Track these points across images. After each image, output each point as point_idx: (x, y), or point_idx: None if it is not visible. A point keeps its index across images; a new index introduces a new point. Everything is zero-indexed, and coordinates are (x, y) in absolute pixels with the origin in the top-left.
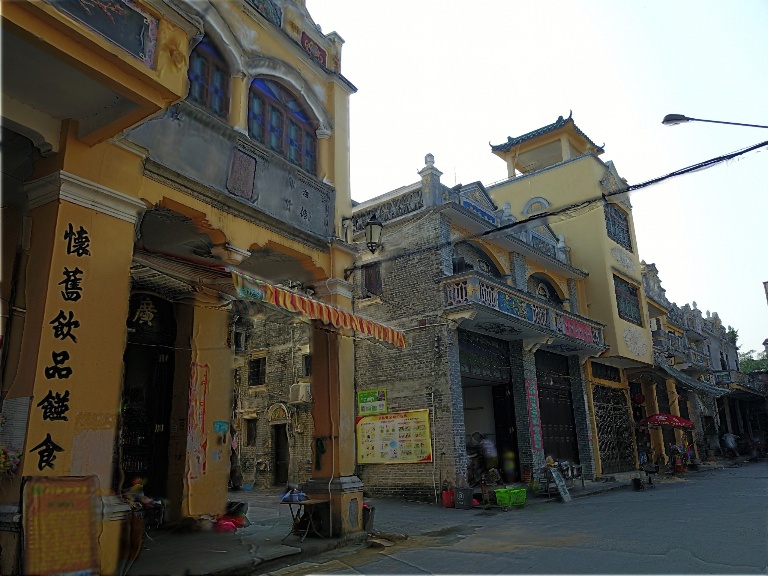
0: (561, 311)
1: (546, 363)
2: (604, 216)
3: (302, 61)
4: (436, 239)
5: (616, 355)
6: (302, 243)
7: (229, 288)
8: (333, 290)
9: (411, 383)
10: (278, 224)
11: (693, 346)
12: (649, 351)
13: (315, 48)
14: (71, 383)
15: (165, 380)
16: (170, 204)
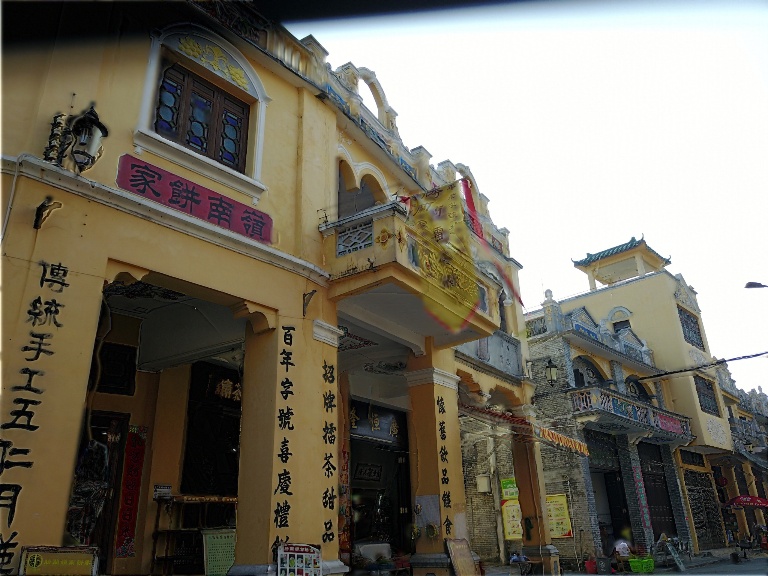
0: (657, 409)
1: (644, 452)
2: (680, 324)
3: (495, 257)
4: (561, 358)
5: (703, 444)
6: (509, 383)
7: (523, 430)
8: (527, 413)
9: (548, 473)
10: (500, 373)
11: (762, 429)
12: (728, 439)
13: (497, 244)
14: (449, 486)
15: (404, 476)
16: (459, 372)
